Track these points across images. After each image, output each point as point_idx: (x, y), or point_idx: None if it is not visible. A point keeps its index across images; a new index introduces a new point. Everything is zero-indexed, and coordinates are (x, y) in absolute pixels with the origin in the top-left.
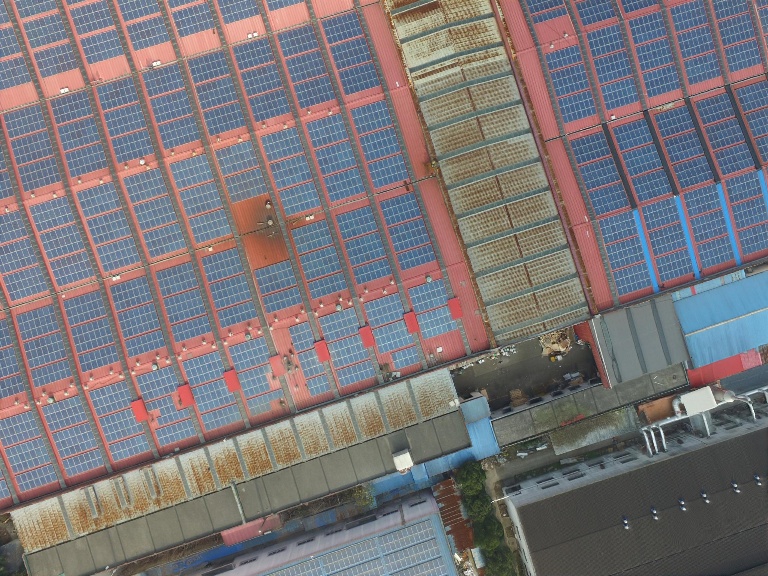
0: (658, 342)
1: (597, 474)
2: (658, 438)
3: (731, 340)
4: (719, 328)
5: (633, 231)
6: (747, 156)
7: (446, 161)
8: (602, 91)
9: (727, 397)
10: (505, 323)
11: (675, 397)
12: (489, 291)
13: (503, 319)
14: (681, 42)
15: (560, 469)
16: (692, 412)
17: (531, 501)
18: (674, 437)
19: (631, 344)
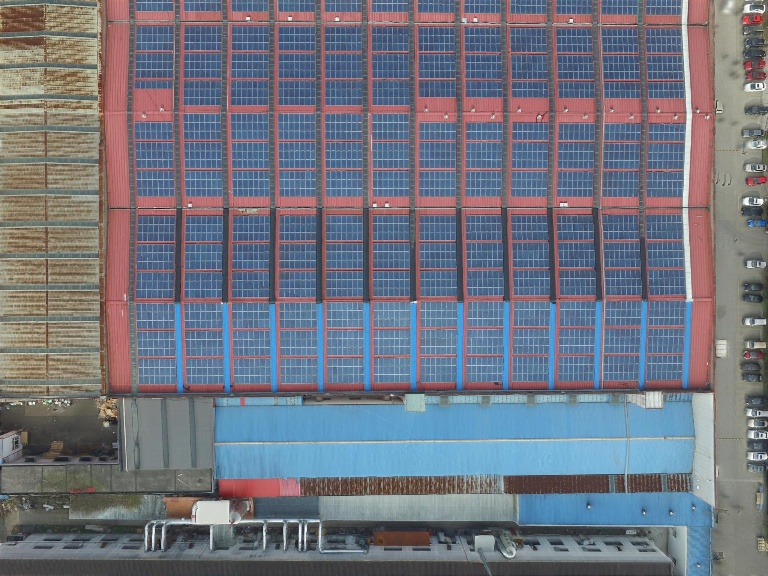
0: (188, 441)
1: (87, 551)
2: (158, 536)
3: (265, 462)
4: (254, 447)
5: (170, 324)
6: (312, 285)
7: (5, 198)
8: (185, 176)
9: (230, 518)
10: (13, 375)
11: (197, 500)
12: (7, 339)
13: (12, 370)
14: (281, 151)
15: (81, 533)
16: (201, 521)
17: (2, 557)
18: (198, 539)
19: (159, 434)
